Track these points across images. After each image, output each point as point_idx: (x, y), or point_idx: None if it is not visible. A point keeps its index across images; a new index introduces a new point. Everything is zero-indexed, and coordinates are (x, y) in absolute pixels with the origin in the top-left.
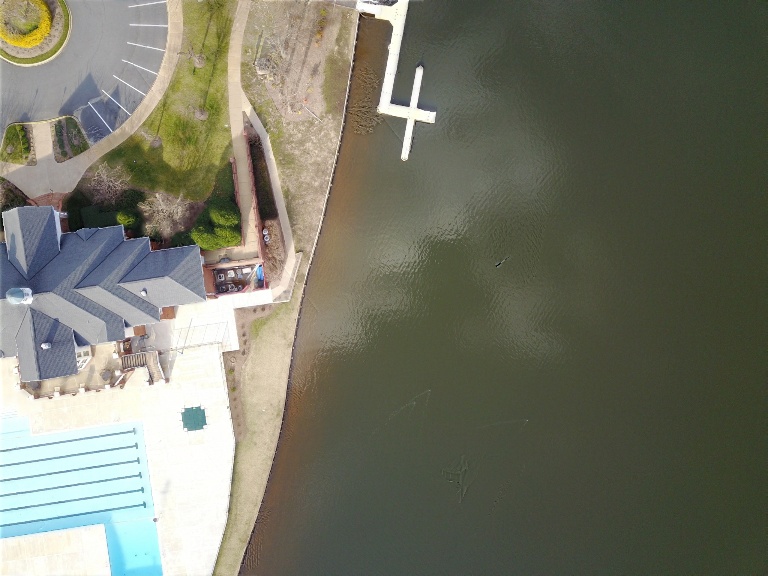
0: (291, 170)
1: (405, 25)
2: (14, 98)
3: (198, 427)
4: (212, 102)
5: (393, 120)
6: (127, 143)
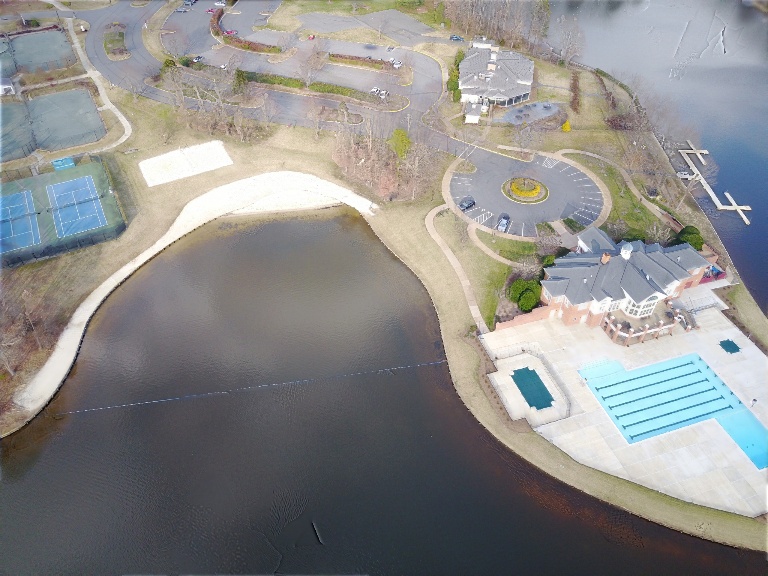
0: None
1: (705, 180)
2: (533, 215)
3: (736, 350)
4: None
5: (727, 213)
6: (605, 224)
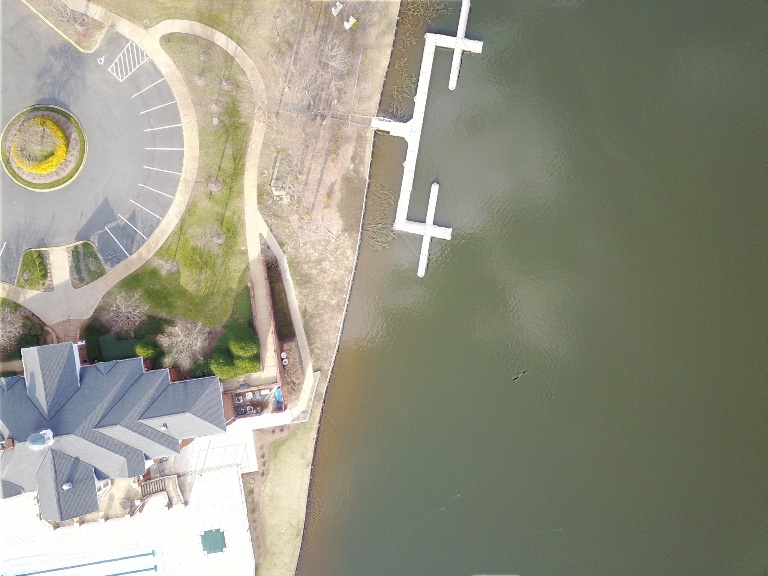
0: (308, 290)
1: (420, 141)
2: (30, 224)
3: (218, 550)
4: (229, 225)
5: (409, 236)
6: (144, 268)
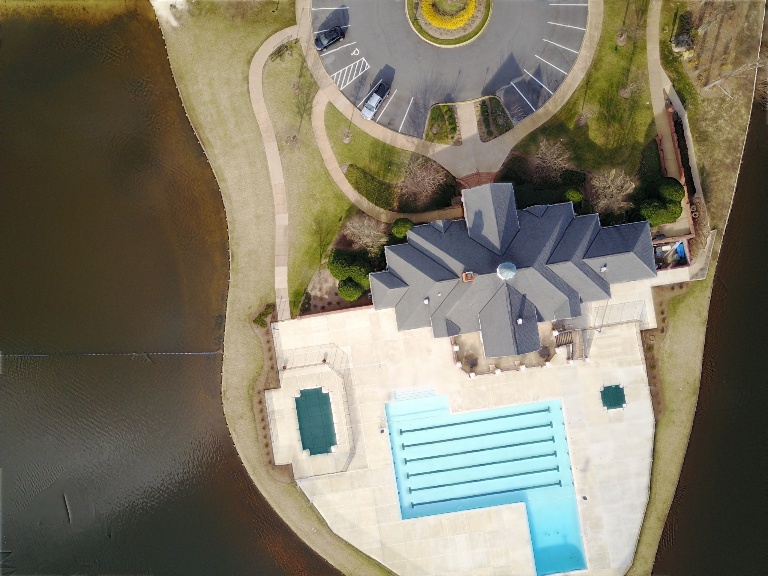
0: (705, 147)
1: None
2: (437, 79)
3: (618, 405)
4: (634, 80)
5: None
6: (551, 122)
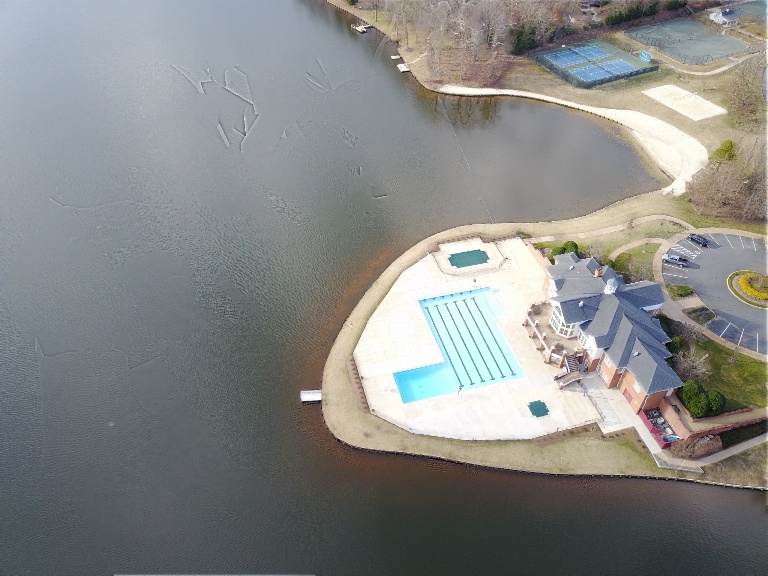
0: (765, 455)
1: None
2: (707, 287)
3: (533, 412)
4: None
5: None
6: (719, 345)
